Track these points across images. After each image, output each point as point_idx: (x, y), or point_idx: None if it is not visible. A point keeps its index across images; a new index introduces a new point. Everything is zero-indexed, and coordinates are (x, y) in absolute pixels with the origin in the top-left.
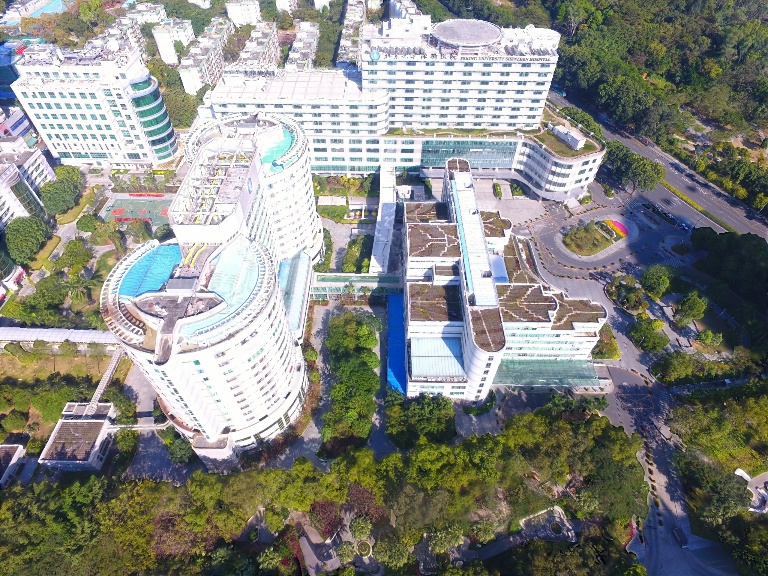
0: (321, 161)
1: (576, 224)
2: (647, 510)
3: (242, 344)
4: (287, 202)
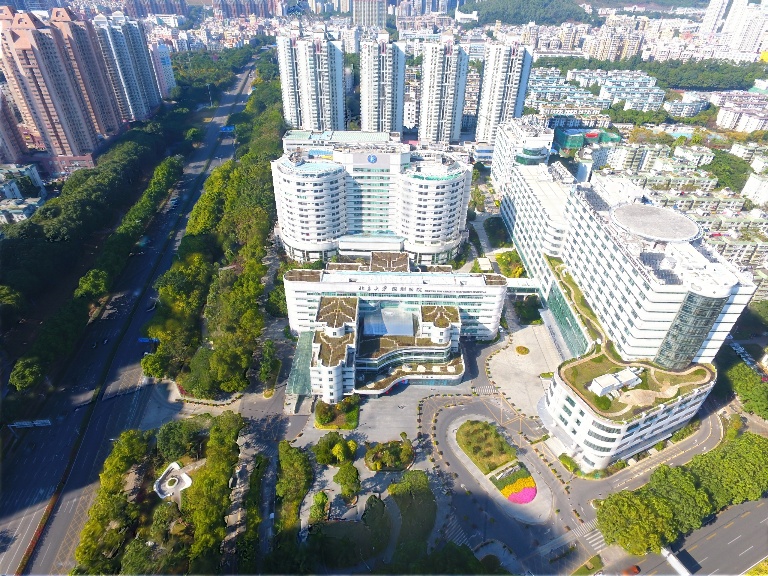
0: (523, 248)
1: (515, 443)
2: (186, 386)
3: (285, 181)
4: (403, 197)
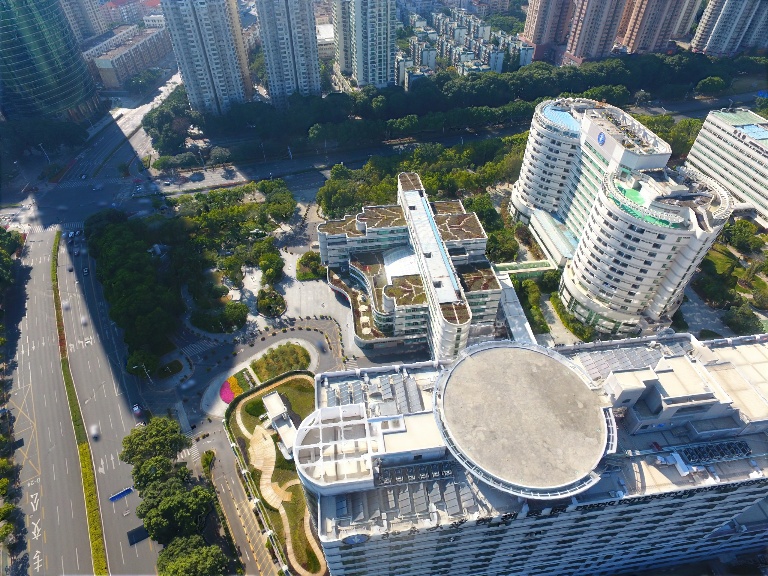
0: None
1: None
2: None
3: None
4: None
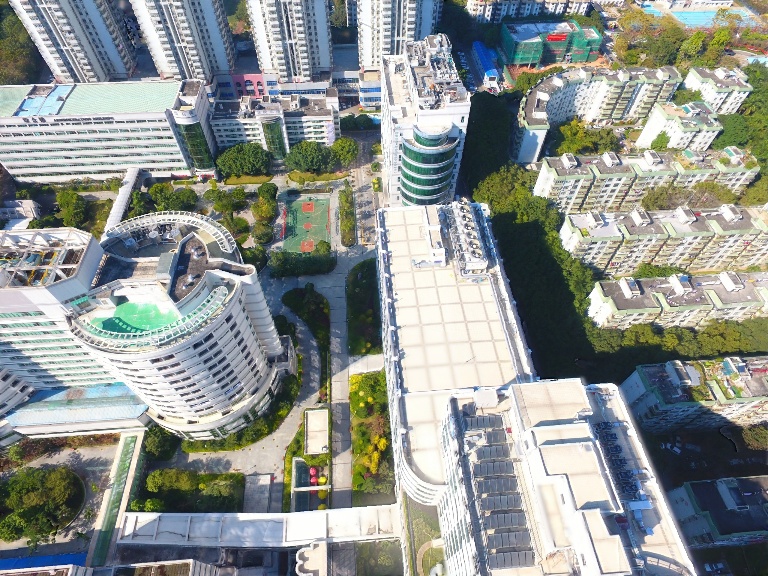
0: None
1: None
2: None
3: None
4: None
